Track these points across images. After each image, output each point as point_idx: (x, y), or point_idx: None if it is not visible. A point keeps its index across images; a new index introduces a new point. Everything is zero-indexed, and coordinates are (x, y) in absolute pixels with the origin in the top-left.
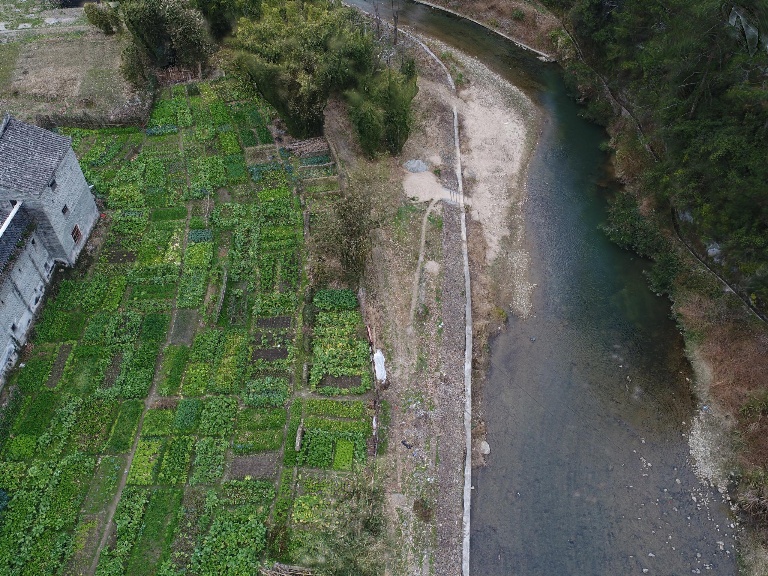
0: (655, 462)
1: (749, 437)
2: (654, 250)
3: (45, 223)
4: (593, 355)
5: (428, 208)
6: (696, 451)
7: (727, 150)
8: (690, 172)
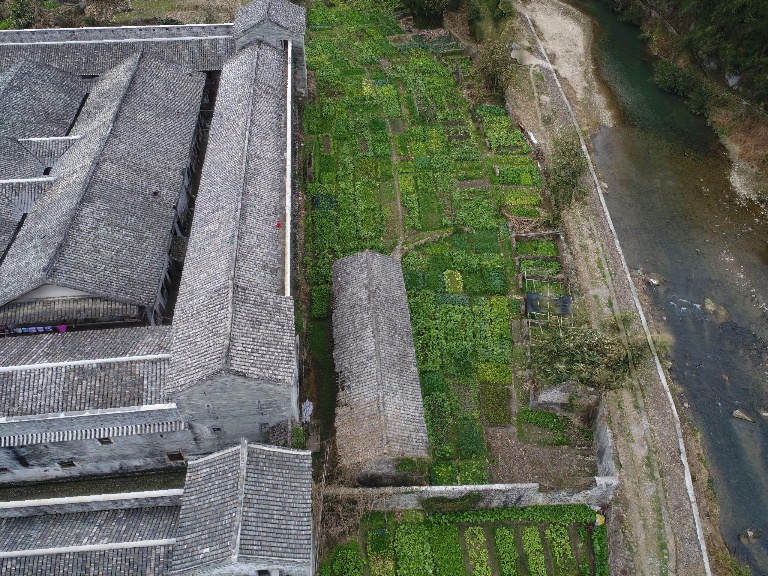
0: (711, 189)
1: (767, 173)
2: (690, 90)
3: (300, 59)
4: (660, 145)
5: (530, 69)
6: (735, 184)
7: (743, 4)
8: (716, 28)
